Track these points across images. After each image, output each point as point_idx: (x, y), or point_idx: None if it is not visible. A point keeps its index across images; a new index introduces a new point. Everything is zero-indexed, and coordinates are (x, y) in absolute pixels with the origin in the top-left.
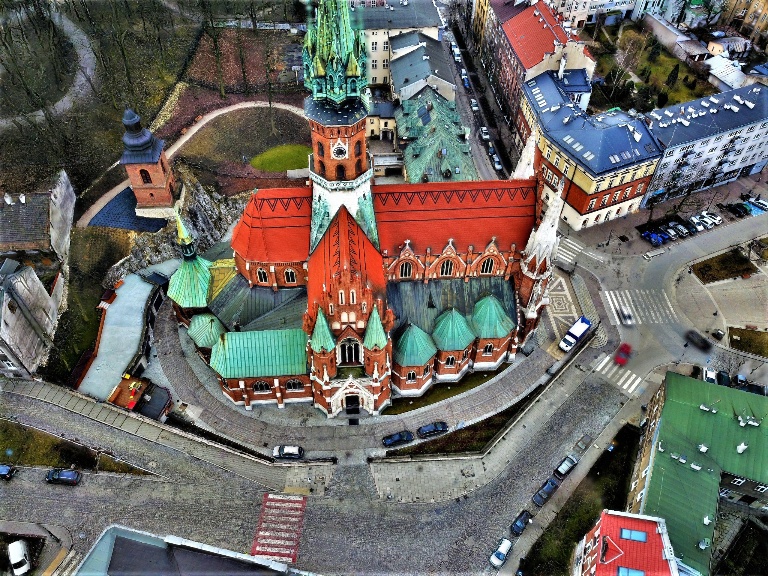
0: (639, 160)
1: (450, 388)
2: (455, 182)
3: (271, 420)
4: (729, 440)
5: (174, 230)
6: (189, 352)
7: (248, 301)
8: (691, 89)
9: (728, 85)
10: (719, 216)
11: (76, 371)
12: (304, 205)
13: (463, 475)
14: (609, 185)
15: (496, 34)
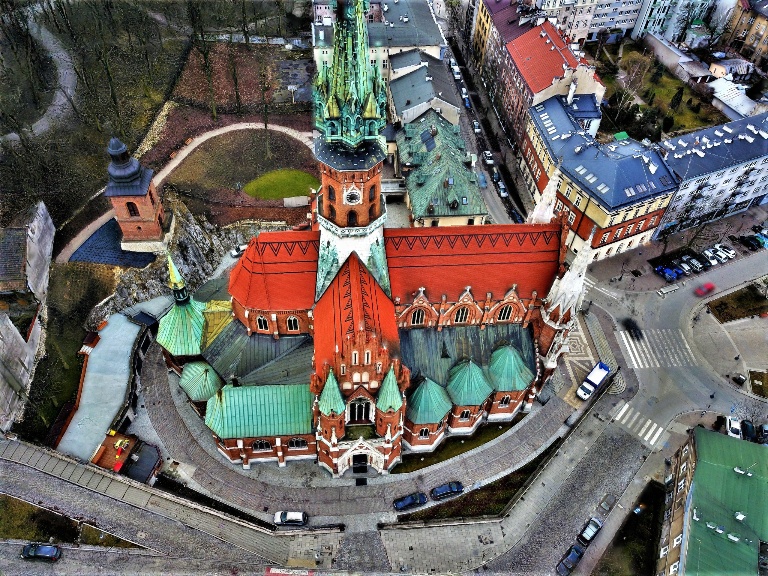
0: (655, 193)
1: (463, 442)
2: (474, 226)
3: (271, 480)
4: (766, 506)
5: (163, 265)
6: (180, 402)
7: (246, 350)
8: (695, 112)
9: (733, 109)
10: (732, 249)
11: (55, 427)
12: (310, 249)
13: (481, 542)
14: (623, 218)
15: (499, 54)
